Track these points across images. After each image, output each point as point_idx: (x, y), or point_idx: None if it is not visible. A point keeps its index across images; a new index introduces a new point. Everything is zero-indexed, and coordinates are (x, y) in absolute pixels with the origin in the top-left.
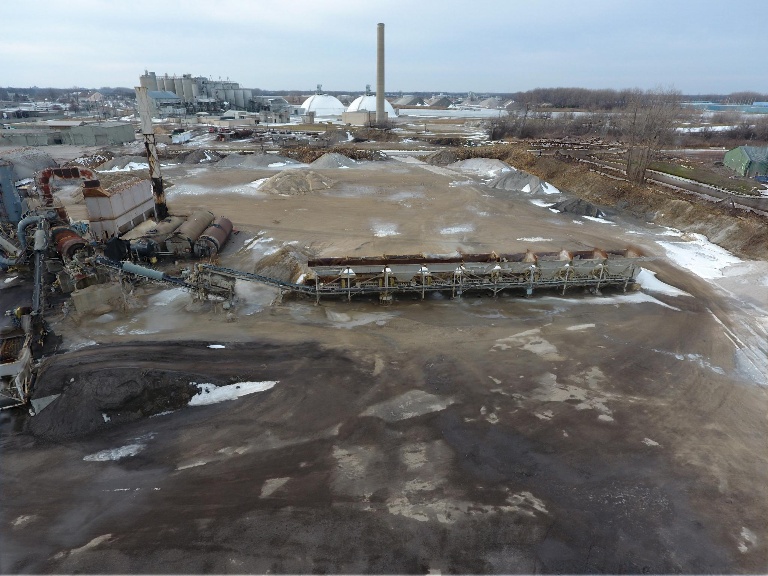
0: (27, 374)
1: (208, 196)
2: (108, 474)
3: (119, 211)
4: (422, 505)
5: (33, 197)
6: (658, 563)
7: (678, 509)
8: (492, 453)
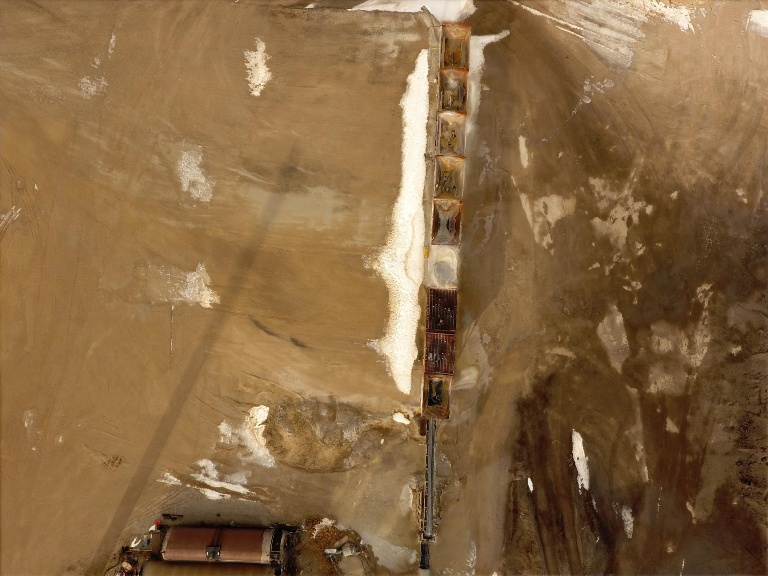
0: None
1: None
2: (645, 519)
3: None
4: (698, 348)
5: None
6: (745, 247)
7: (720, 215)
8: (667, 297)
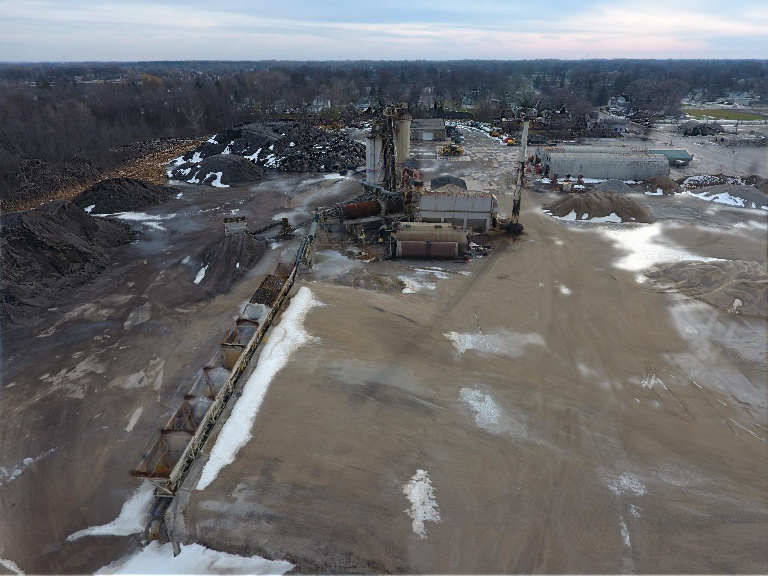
0: (236, 233)
1: (603, 242)
2: (175, 260)
3: (429, 207)
4: (81, 310)
5: (561, 192)
6: None
7: None
8: None
